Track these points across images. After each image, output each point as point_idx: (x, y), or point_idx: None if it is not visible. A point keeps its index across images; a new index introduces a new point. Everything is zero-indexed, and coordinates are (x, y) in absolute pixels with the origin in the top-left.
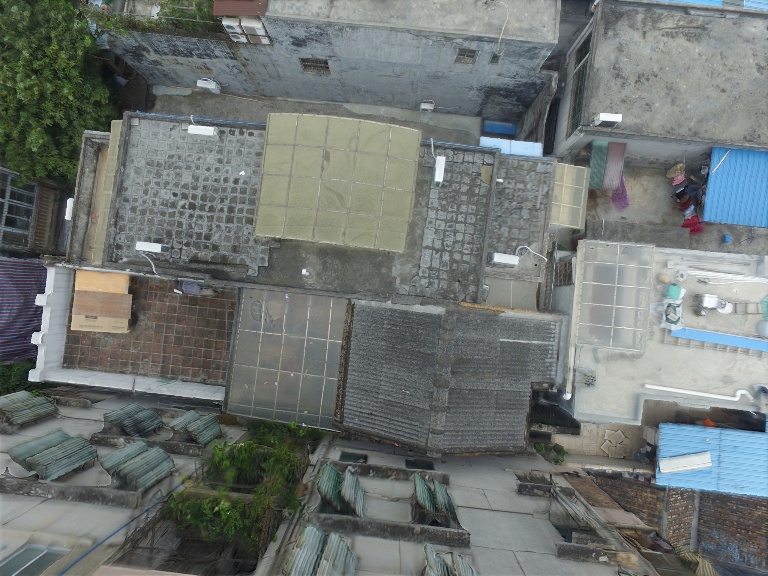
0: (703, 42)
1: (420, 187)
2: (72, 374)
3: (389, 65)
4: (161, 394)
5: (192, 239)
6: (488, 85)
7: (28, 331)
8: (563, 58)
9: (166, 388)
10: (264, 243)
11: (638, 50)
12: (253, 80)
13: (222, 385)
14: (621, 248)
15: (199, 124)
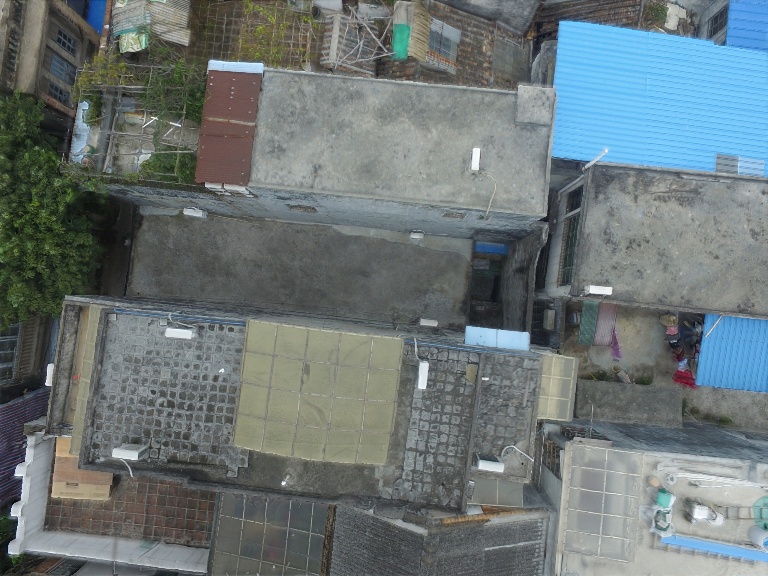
0: (696, 207)
1: (404, 386)
2: (53, 541)
3: (376, 213)
4: (143, 565)
5: (171, 438)
6: (478, 227)
7: (12, 471)
8: (555, 194)
9: (148, 559)
10: None
11: (629, 215)
12: (240, 209)
13: (206, 547)
14: (609, 453)
15: (177, 321)
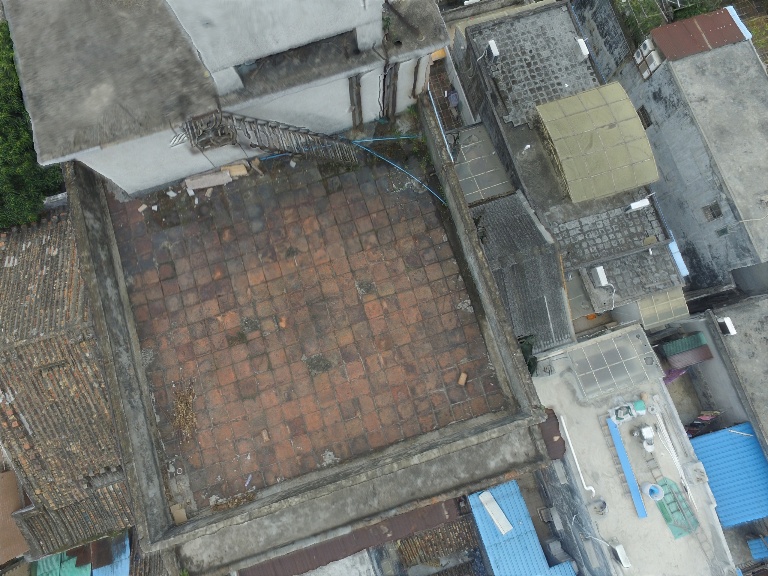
0: None
1: (618, 201)
2: None
3: (673, 166)
4: None
5: (508, 74)
6: (695, 246)
7: None
8: (745, 296)
9: None
10: (529, 118)
11: None
12: None
13: None
14: (650, 354)
15: None
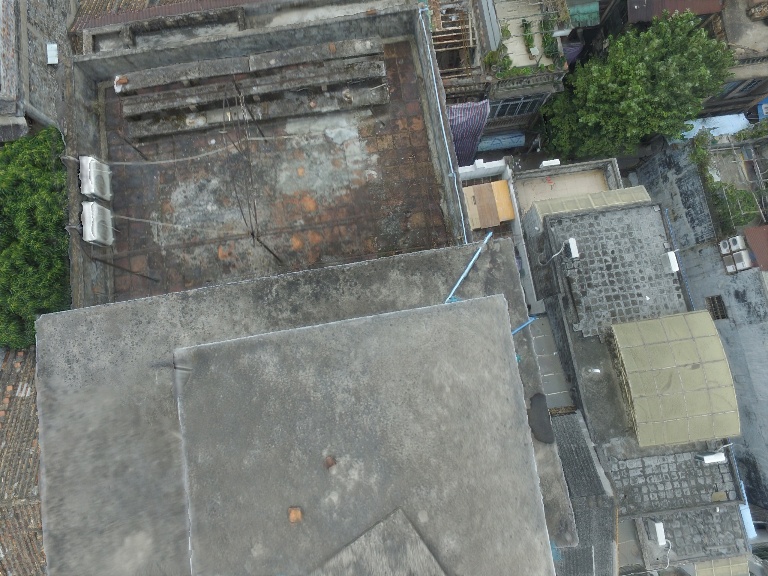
0: None
1: None
2: None
3: (745, 372)
4: None
5: (585, 274)
6: (757, 461)
7: None
8: None
9: None
10: (601, 330)
11: None
12: None
13: None
14: None
15: None
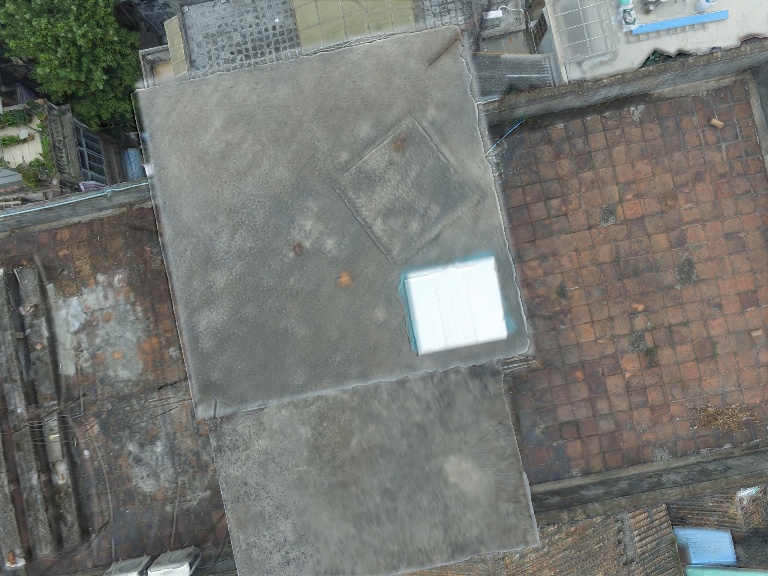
0: None
1: None
2: None
3: None
4: None
5: None
6: None
7: None
8: None
9: None
10: None
11: None
12: None
13: None
14: None
15: None
